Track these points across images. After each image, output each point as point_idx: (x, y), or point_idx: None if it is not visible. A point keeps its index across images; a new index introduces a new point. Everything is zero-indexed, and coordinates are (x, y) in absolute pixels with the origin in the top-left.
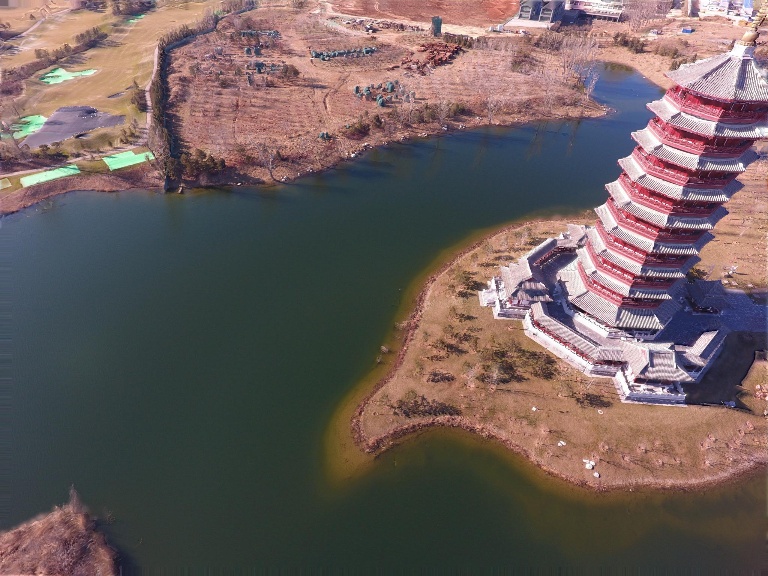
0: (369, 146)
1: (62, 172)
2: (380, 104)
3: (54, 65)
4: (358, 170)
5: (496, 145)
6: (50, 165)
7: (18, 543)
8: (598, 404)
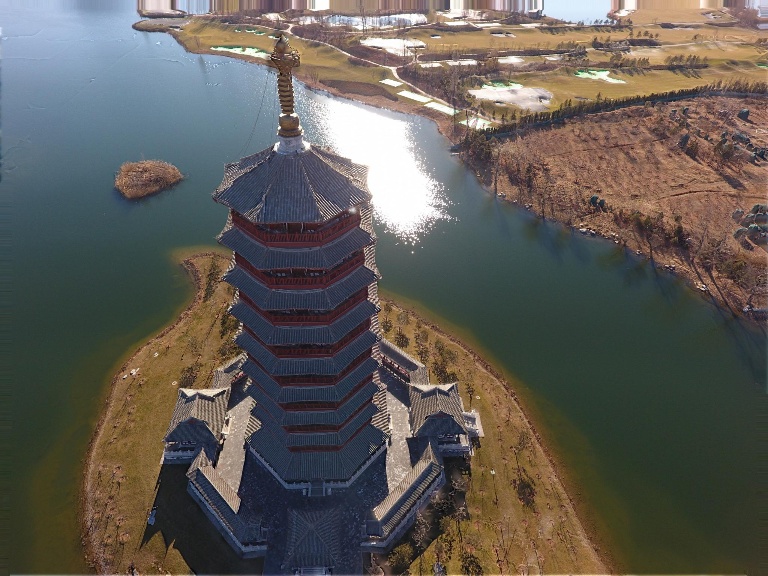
0: (617, 240)
1: (448, 110)
2: (736, 232)
3: (613, 69)
4: (552, 236)
5: (747, 371)
6: (456, 105)
7: (169, 169)
8: (183, 383)
